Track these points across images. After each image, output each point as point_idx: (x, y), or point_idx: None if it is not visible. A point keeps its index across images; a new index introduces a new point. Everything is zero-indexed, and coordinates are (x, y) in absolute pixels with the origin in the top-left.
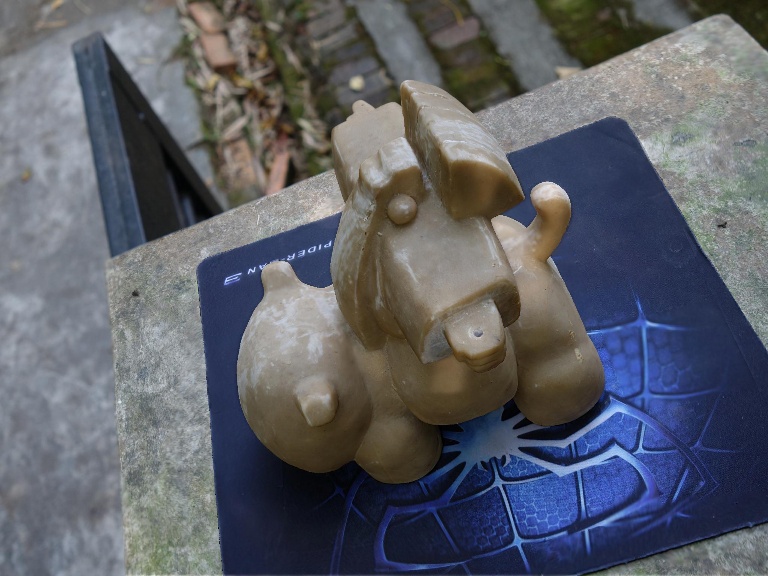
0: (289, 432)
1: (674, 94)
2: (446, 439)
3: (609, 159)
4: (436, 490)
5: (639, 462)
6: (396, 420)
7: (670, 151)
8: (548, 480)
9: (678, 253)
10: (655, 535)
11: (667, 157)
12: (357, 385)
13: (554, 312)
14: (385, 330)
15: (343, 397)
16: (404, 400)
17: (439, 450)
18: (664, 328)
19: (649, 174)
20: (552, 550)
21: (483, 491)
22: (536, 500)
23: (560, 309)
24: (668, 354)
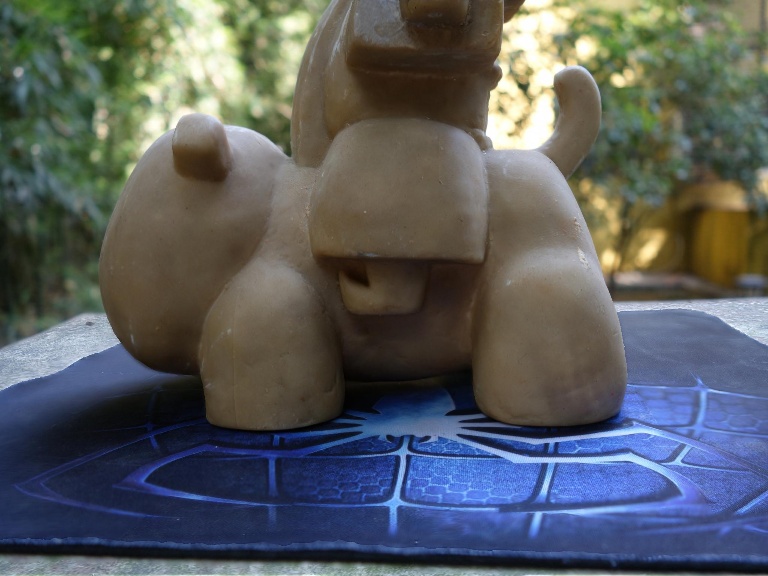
0: (142, 196)
1: (765, 314)
2: (348, 415)
3: (677, 321)
4: (294, 444)
5: (671, 471)
6: (288, 269)
7: (758, 329)
8: (491, 462)
9: (764, 363)
10: (689, 538)
11: (753, 331)
12: (262, 183)
13: (556, 181)
14: (329, 110)
15: (236, 177)
16: (312, 222)
17: (329, 398)
18: (737, 395)
19: (728, 330)
20: (456, 520)
21: (370, 455)
22: (457, 474)
23: (566, 189)
24: (742, 409)
